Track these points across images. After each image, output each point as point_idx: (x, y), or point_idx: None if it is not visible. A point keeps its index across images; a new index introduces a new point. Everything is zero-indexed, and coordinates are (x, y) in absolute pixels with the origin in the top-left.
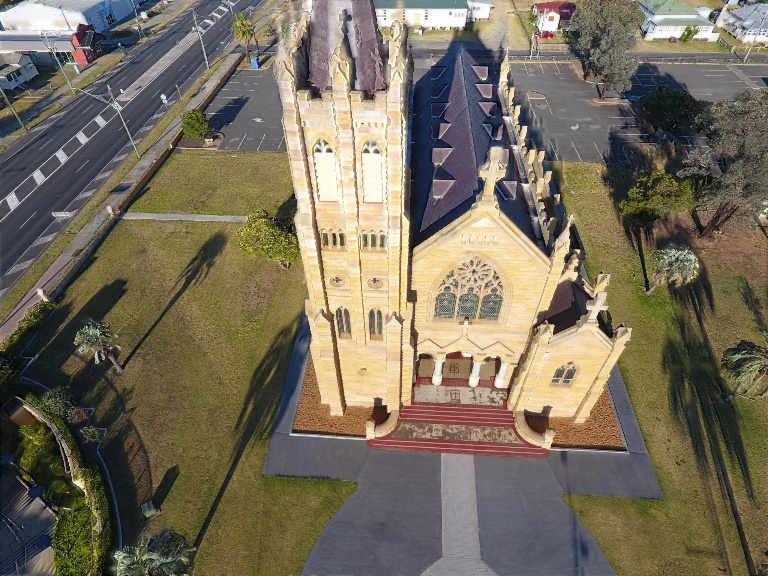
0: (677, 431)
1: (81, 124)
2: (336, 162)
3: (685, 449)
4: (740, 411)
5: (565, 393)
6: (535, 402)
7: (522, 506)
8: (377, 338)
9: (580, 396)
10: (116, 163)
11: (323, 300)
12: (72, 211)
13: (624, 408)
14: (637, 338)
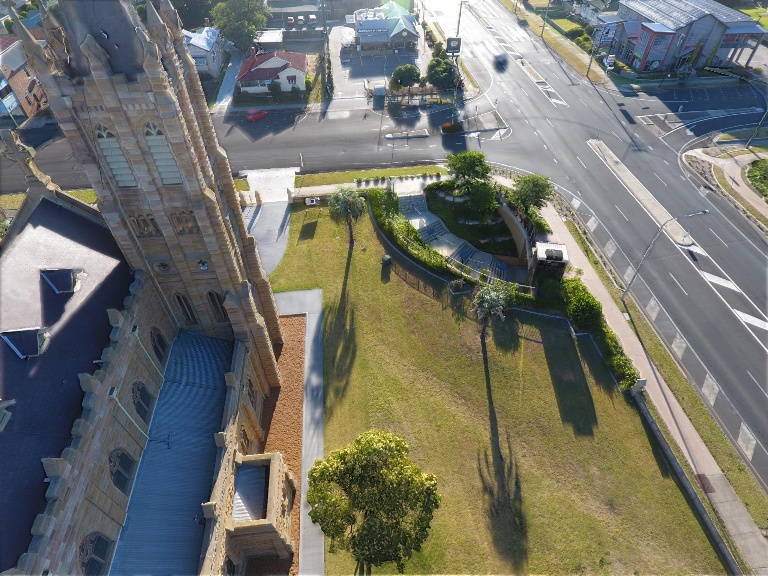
0: None
1: None
2: None
3: None
4: None
5: None
6: None
7: None
8: None
9: None
10: None
11: None
12: None
13: None
14: None
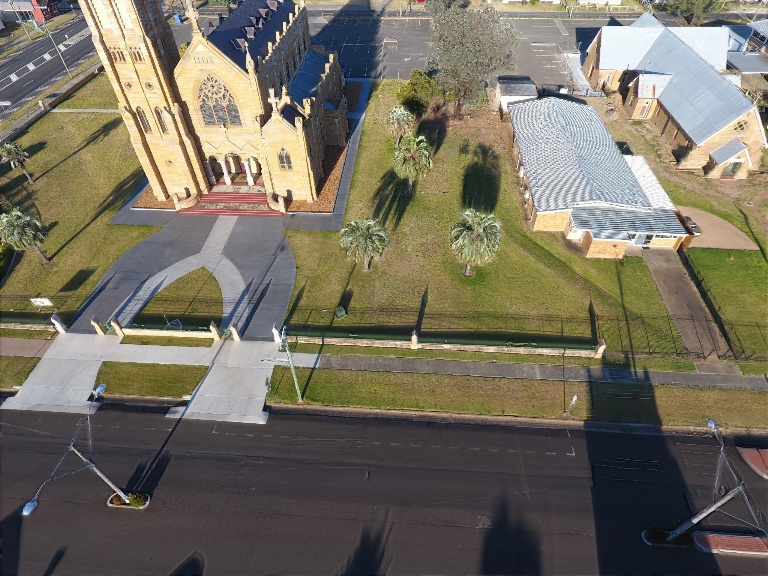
0: (369, 206)
1: (32, 59)
2: (102, 2)
3: (368, 213)
4: (415, 198)
5: (292, 177)
6: (279, 187)
7: (256, 235)
8: (168, 133)
9: (302, 179)
10: (54, 81)
11: (123, 98)
12: (16, 108)
13: (342, 196)
14: (373, 167)
